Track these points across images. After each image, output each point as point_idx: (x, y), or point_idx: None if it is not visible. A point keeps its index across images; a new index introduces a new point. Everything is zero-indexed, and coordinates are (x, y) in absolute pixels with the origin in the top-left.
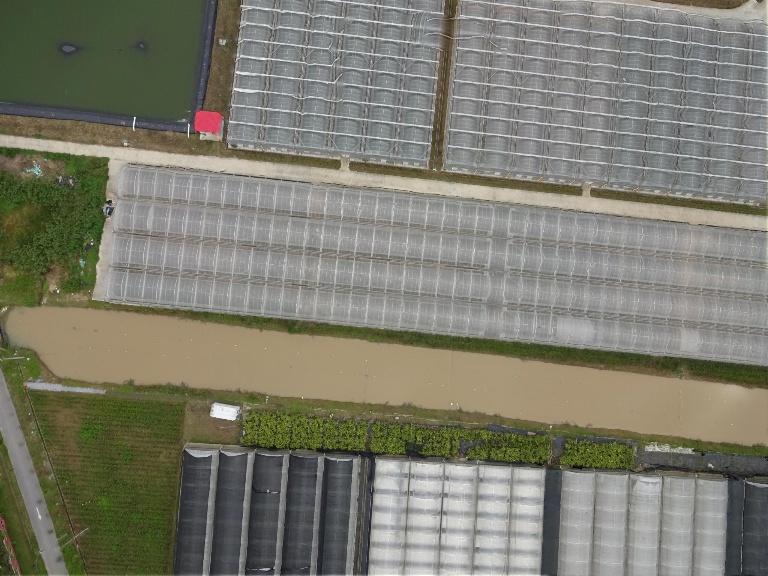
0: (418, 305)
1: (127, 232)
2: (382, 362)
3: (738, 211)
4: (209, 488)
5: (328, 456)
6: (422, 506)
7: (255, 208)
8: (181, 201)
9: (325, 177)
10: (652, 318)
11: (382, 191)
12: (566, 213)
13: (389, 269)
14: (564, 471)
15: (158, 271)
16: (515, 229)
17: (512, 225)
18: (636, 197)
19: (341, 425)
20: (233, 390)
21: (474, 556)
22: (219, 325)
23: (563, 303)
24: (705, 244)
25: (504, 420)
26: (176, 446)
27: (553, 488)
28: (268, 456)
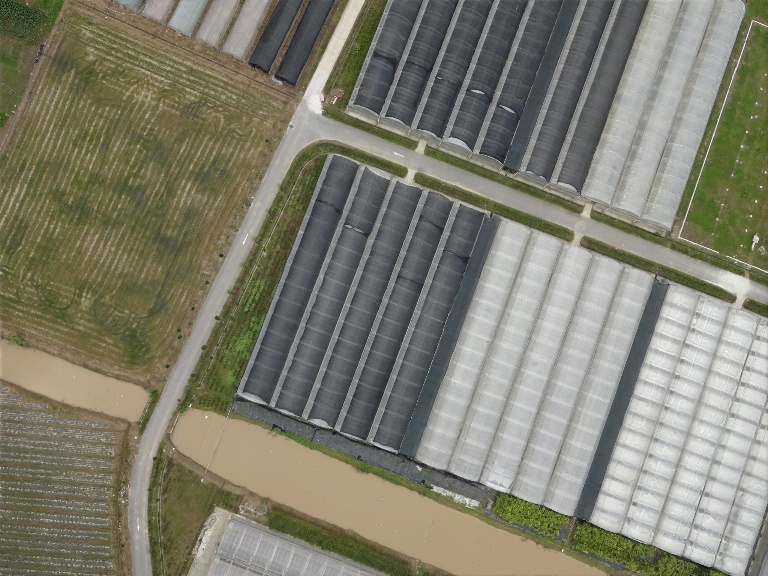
0: None
1: None
2: None
3: None
4: None
5: None
6: (716, 525)
7: None
8: None
9: None
10: None
11: None
12: None
13: None
14: None
15: None
16: None
17: None
18: None
19: None
20: None
21: (678, 461)
22: None
23: None
24: None
25: (606, 571)
26: None
27: None
28: None
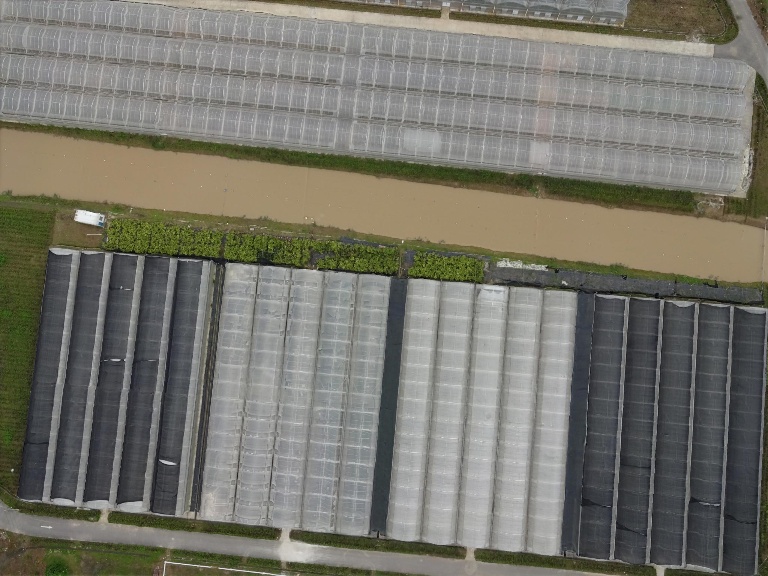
0: (270, 117)
1: (6, 51)
2: (241, 178)
3: (600, 31)
4: (69, 284)
5: (180, 258)
6: (267, 307)
7: (121, 28)
8: (54, 22)
9: (192, 3)
10: (503, 132)
11: (242, 13)
12: (419, 30)
13: (245, 85)
14: (409, 279)
15: (32, 87)
16: (366, 44)
17: (364, 42)
18: (495, 19)
19: (197, 233)
20: (101, 202)
21: (317, 358)
22: (90, 142)
23: (412, 115)
24: (558, 57)
25: (356, 234)
26: (46, 251)
27: (399, 297)
28: (123, 255)
